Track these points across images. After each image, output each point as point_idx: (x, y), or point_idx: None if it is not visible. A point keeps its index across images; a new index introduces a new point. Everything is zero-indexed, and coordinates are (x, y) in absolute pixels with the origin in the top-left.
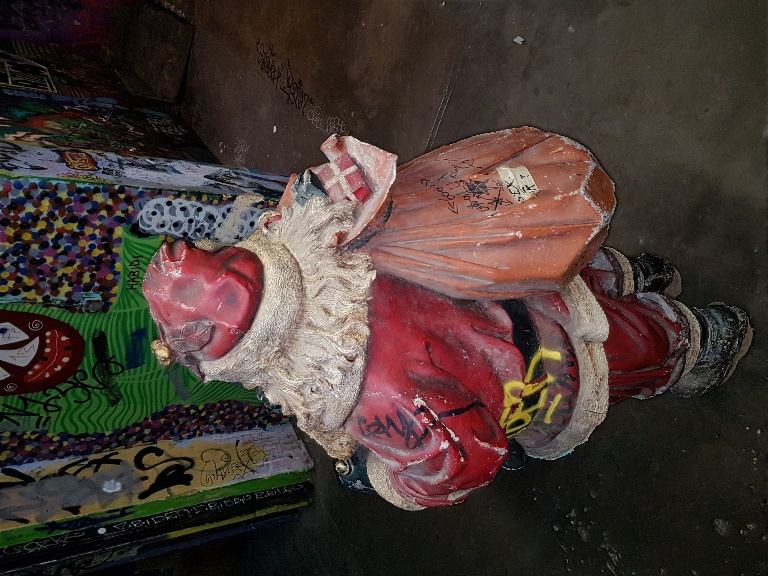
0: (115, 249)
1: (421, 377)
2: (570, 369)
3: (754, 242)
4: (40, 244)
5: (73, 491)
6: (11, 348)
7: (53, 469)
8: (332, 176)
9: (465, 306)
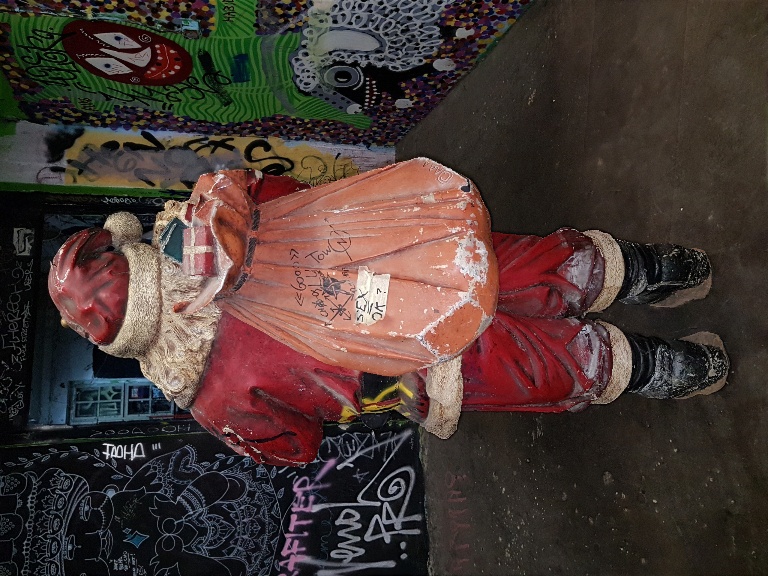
0: None
1: (238, 412)
2: (419, 406)
3: None
4: None
5: (191, 167)
6: (128, 52)
7: (180, 141)
8: (189, 244)
9: None
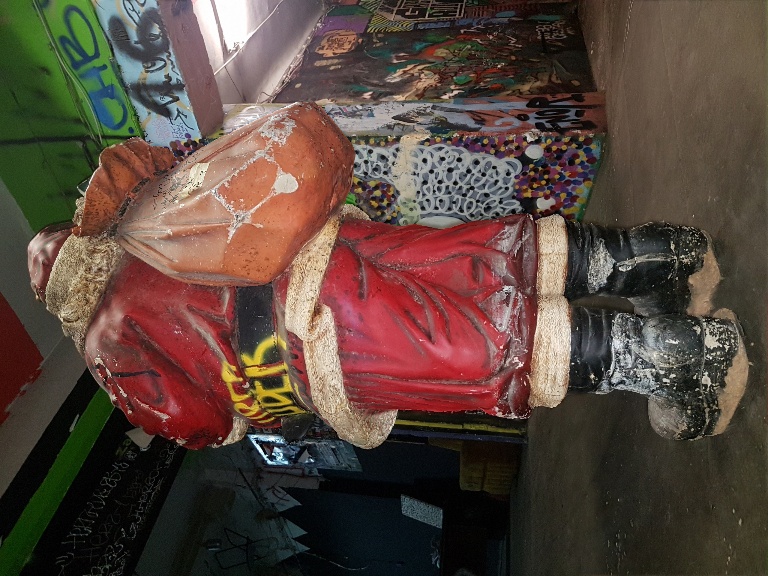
0: None
1: (111, 342)
2: (294, 361)
3: None
4: None
5: None
6: None
7: None
8: None
9: (205, 287)
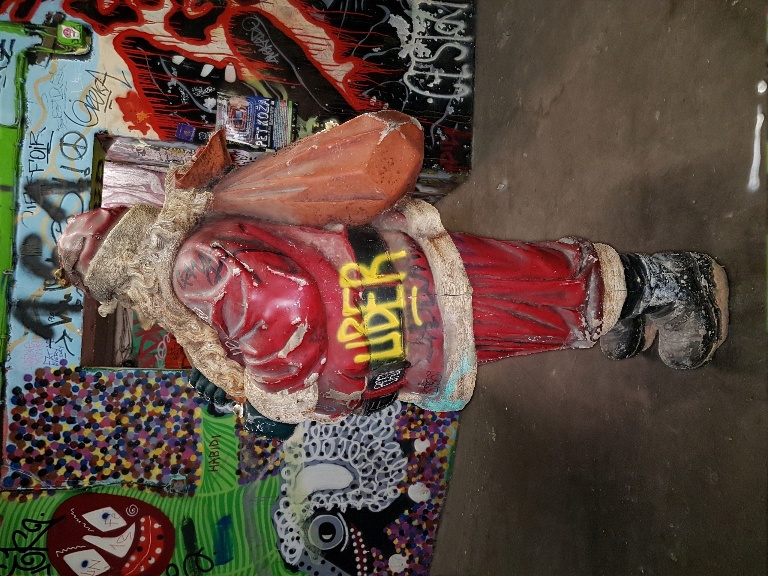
0: (196, 430)
1: (227, 238)
2: (417, 261)
3: (690, 196)
4: (136, 427)
5: None
6: (112, 536)
7: None
8: None
9: None
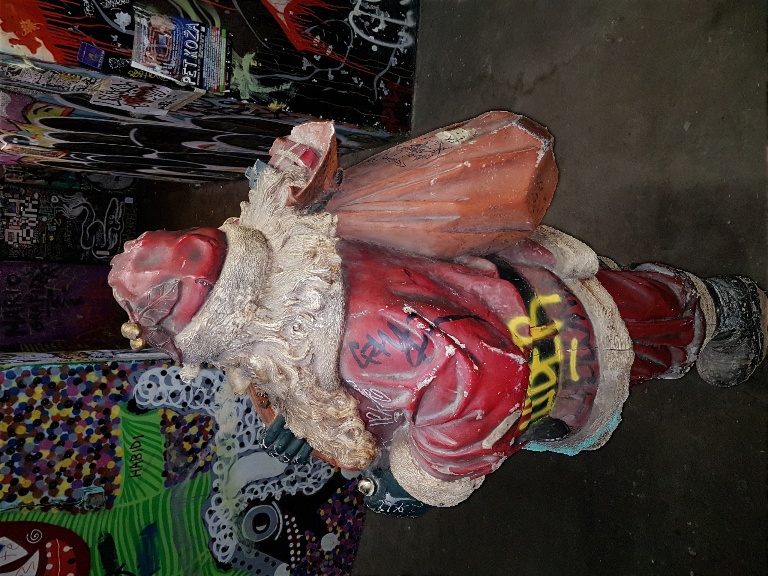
0: (114, 431)
1: (406, 294)
2: (575, 308)
3: (724, 216)
4: (35, 437)
5: None
6: (8, 570)
7: None
8: (279, 157)
9: None
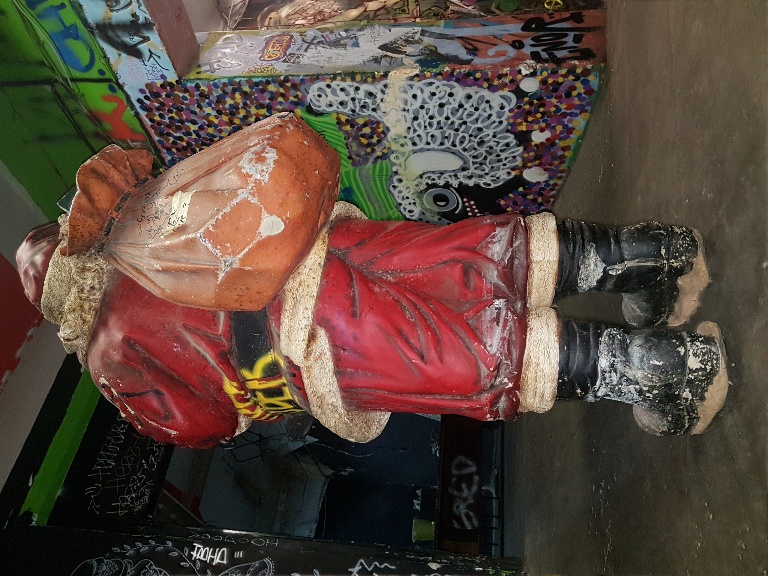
0: None
1: (113, 362)
2: (292, 379)
3: (767, 250)
4: None
5: None
6: None
7: None
8: None
9: None
